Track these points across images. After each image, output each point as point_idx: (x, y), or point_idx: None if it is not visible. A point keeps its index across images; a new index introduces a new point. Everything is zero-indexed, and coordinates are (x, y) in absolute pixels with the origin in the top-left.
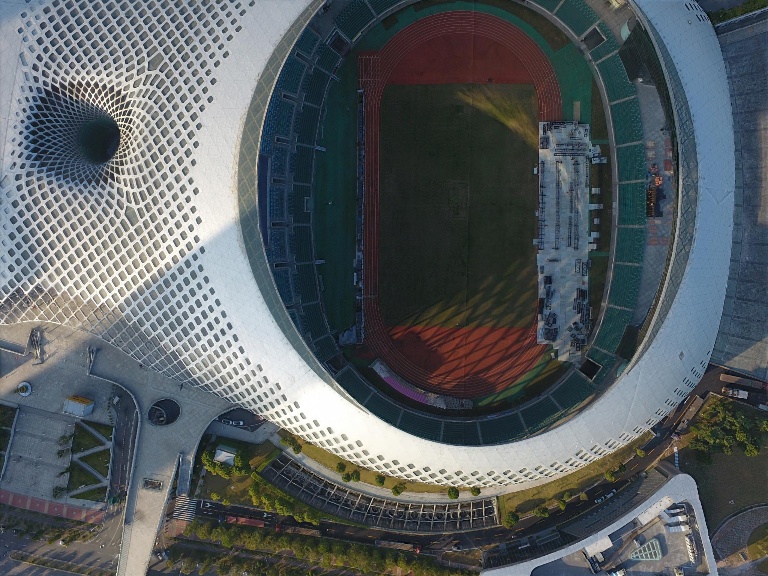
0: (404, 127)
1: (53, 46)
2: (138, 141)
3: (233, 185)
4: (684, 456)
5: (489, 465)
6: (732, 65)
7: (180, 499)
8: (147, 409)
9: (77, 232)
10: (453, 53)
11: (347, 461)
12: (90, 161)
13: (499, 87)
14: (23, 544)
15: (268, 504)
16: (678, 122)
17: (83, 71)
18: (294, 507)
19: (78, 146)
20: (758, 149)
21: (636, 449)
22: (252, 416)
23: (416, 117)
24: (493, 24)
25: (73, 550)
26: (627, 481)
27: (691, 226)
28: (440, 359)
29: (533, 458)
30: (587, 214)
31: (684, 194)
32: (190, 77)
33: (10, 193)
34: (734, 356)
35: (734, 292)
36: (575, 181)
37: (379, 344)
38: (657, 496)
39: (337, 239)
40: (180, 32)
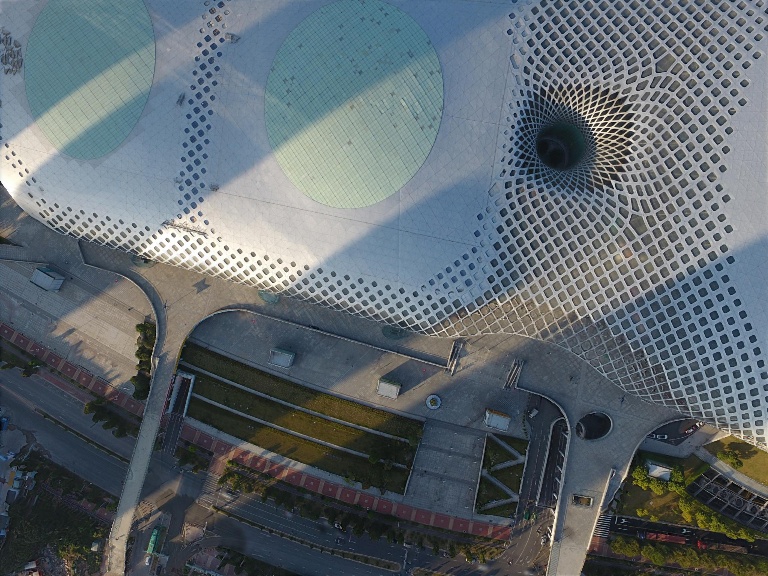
0: None
1: (544, 48)
2: (647, 146)
3: None
4: None
5: None
6: None
7: None
8: (576, 423)
9: (570, 241)
10: None
11: None
12: None
13: None
14: (426, 561)
15: (704, 520)
16: None
17: (578, 74)
18: None
19: None
20: None
21: None
22: (676, 429)
23: None
24: None
25: (478, 567)
26: None
27: None
28: None
29: None
30: None
31: None
32: (712, 79)
33: (498, 201)
34: None
35: None
36: None
37: None
38: None
39: None
40: (692, 32)
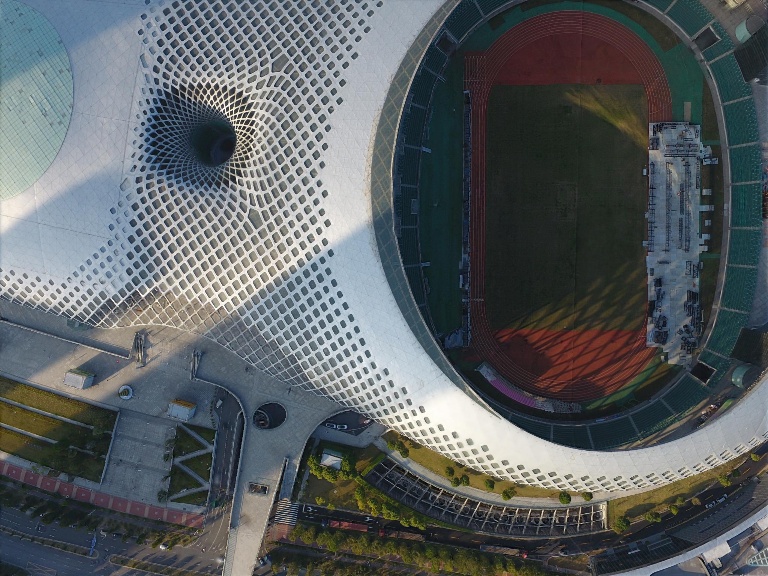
0: (511, 128)
1: (173, 48)
2: (262, 143)
3: (366, 187)
4: None
5: (618, 470)
6: None
7: (282, 503)
8: (253, 413)
9: (198, 235)
10: (561, 53)
11: (454, 465)
12: (202, 163)
13: (608, 87)
14: (123, 548)
15: (375, 508)
16: None
17: (204, 73)
18: (400, 511)
19: (190, 148)
20: None
21: (748, 453)
22: (356, 420)
23: (523, 118)
24: (602, 24)
25: (173, 554)
26: (738, 486)
27: None
28: (547, 362)
29: (664, 463)
30: (698, 216)
31: None
32: (317, 78)
33: (130, 196)
34: None
35: None
36: (686, 182)
37: (485, 347)
38: None
39: (442, 241)
40: (305, 33)
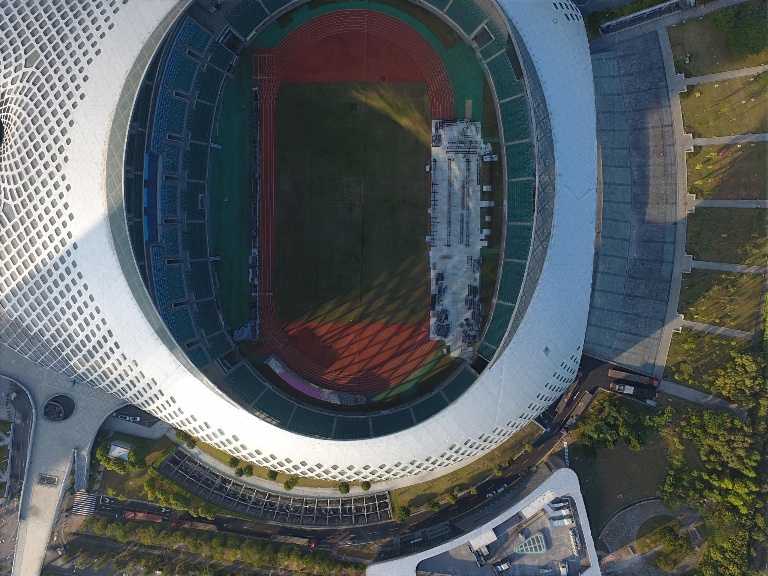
0: (299, 125)
1: None
2: (15, 138)
3: (102, 181)
4: (574, 451)
5: (362, 459)
6: (620, 64)
7: (79, 494)
8: (42, 405)
9: None
10: (347, 51)
11: None
12: None
13: (392, 85)
14: None
15: (163, 499)
16: (534, 120)
17: None
18: (189, 502)
19: None
20: (646, 147)
21: (526, 444)
22: None
23: (310, 115)
24: (386, 23)
25: None
26: (518, 476)
27: (548, 222)
28: (334, 355)
29: (405, 452)
30: (478, 211)
31: (540, 191)
32: (64, 74)
33: None
34: (622, 352)
35: (622, 289)
36: (467, 179)
37: (274, 340)
38: (540, 490)
39: (233, 236)
40: (56, 29)
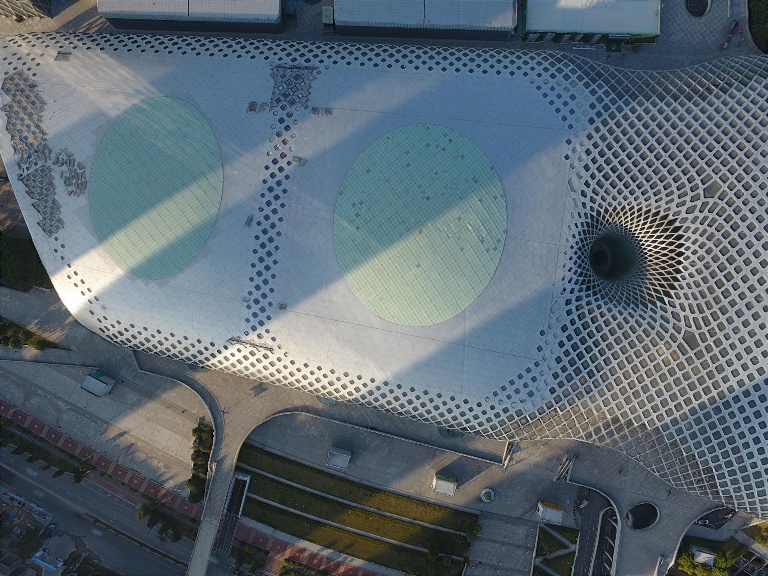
0: None
1: (600, 172)
2: (697, 267)
3: None
4: None
5: None
6: None
7: None
8: None
9: (627, 355)
10: None
11: None
12: (599, 277)
13: None
14: None
15: None
16: None
17: (631, 197)
18: None
19: None
20: None
21: None
22: (716, 514)
23: None
24: None
25: None
26: None
27: None
28: None
29: None
30: None
31: None
32: (756, 206)
33: (559, 318)
34: None
35: None
36: None
37: None
38: None
39: None
40: (736, 160)
